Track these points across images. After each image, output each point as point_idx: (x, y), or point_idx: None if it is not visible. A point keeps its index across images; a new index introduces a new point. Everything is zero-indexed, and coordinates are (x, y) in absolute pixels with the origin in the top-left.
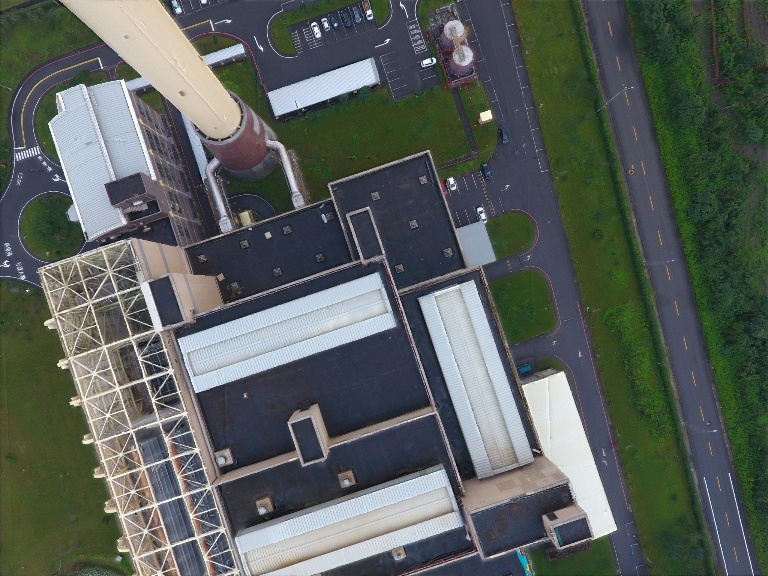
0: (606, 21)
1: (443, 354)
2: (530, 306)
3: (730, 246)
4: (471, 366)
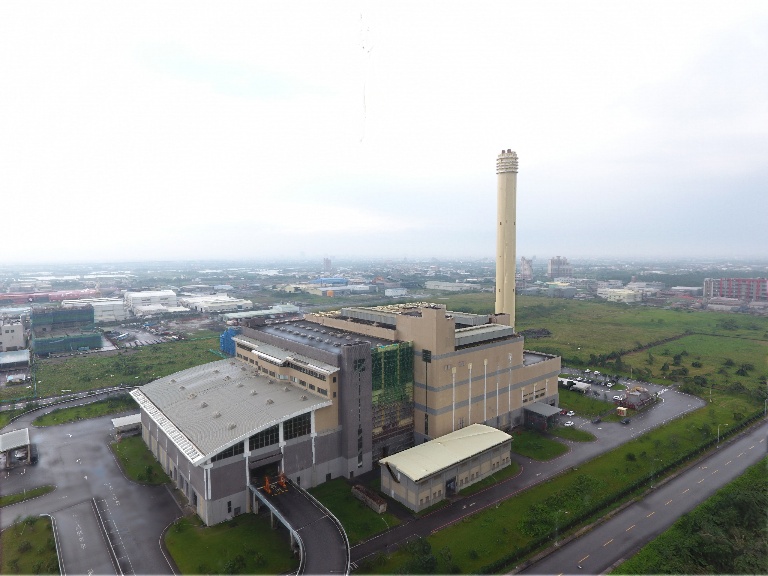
0: None
1: None
2: (541, 447)
3: None
4: None
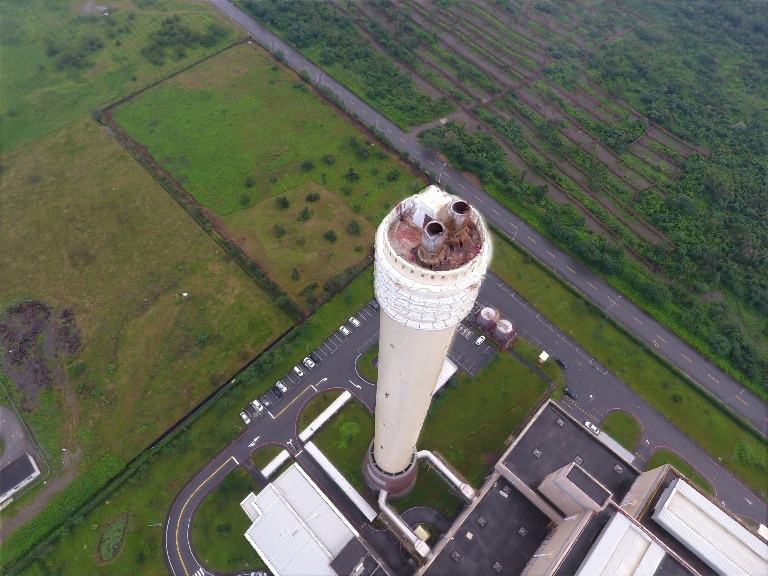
0: (565, 267)
1: (713, 556)
2: None
3: (758, 361)
4: (738, 554)
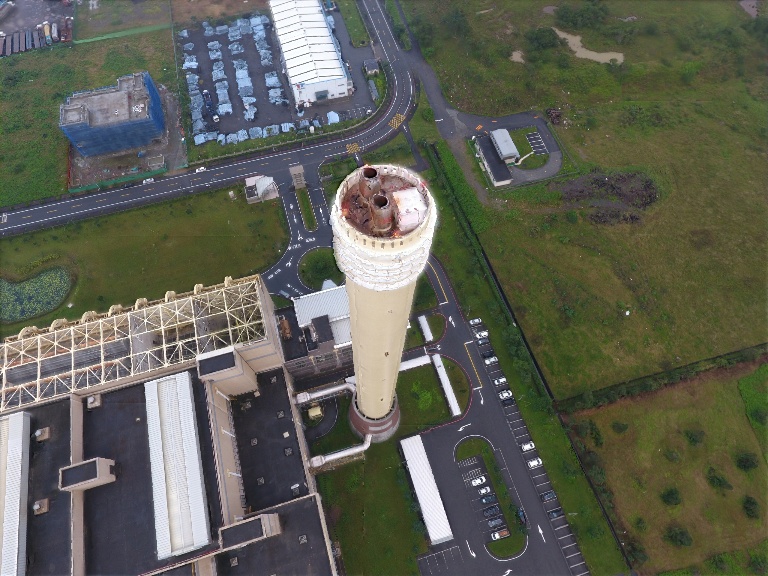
0: None
1: None
2: None
3: None
4: None
